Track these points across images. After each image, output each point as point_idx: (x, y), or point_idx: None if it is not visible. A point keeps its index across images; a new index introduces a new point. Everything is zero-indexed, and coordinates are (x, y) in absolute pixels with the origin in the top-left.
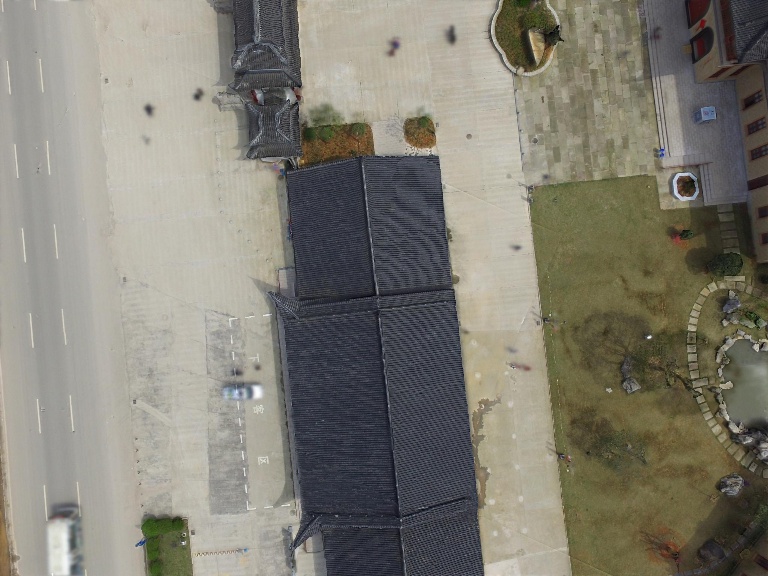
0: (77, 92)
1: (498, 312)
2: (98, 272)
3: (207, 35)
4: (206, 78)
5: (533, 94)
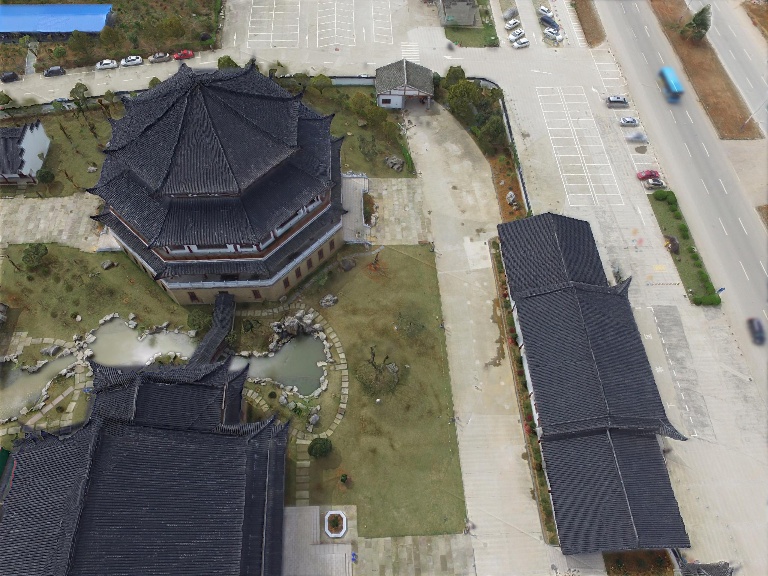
0: None
1: (489, 428)
2: None
3: None
4: None
5: None
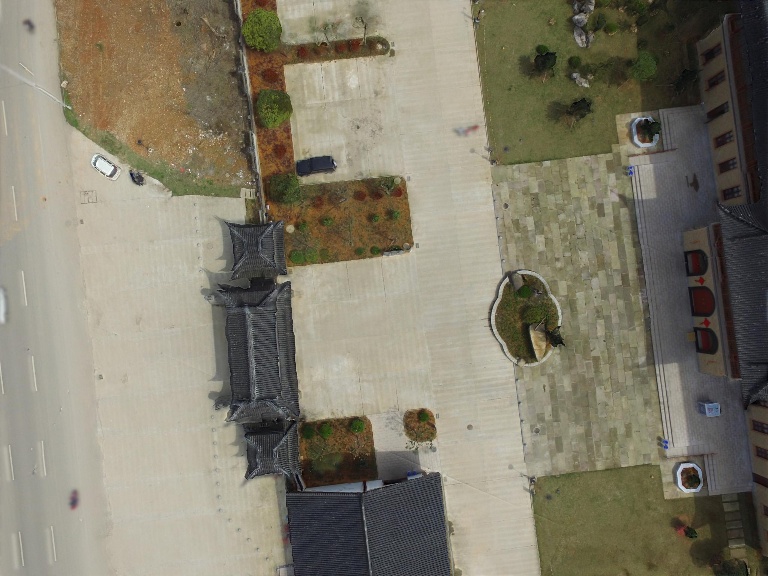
0: (71, 390)
1: None
2: (97, 573)
3: (202, 328)
4: (202, 373)
5: (534, 383)
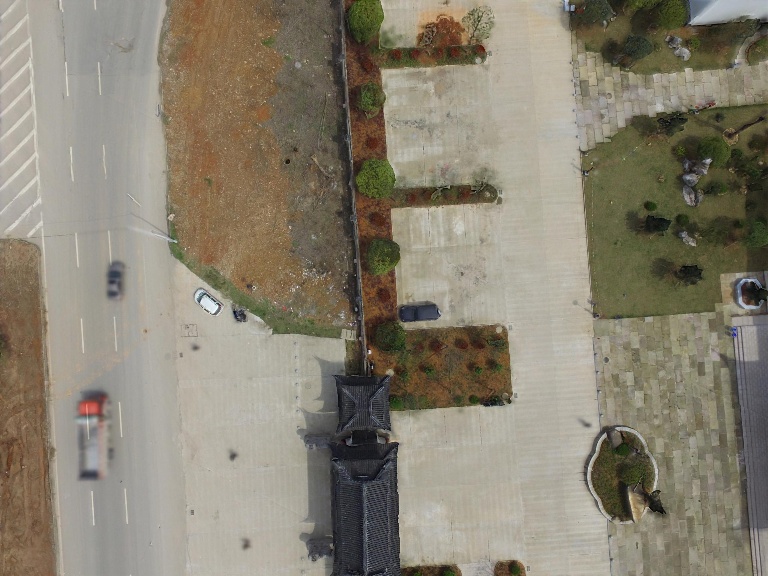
0: (162, 524)
1: None
2: None
3: (296, 468)
4: (294, 514)
5: (627, 540)
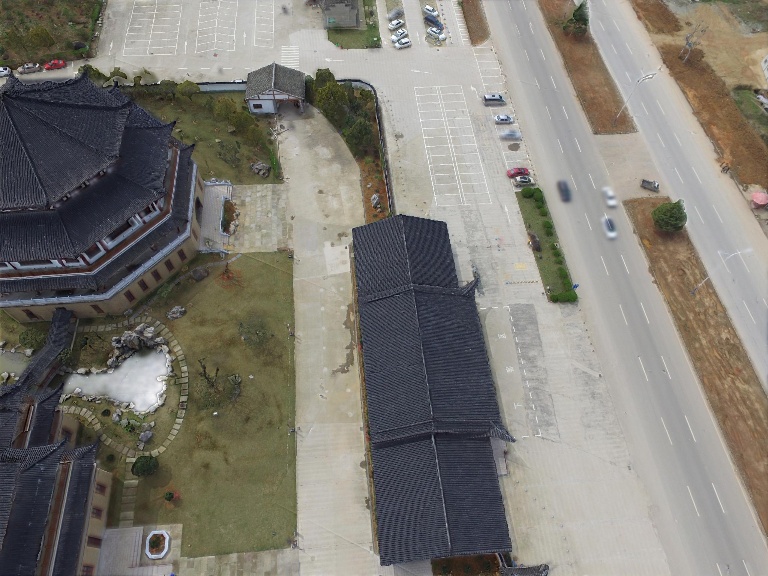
0: None
1: (330, 438)
2: (652, 475)
3: None
4: None
5: None
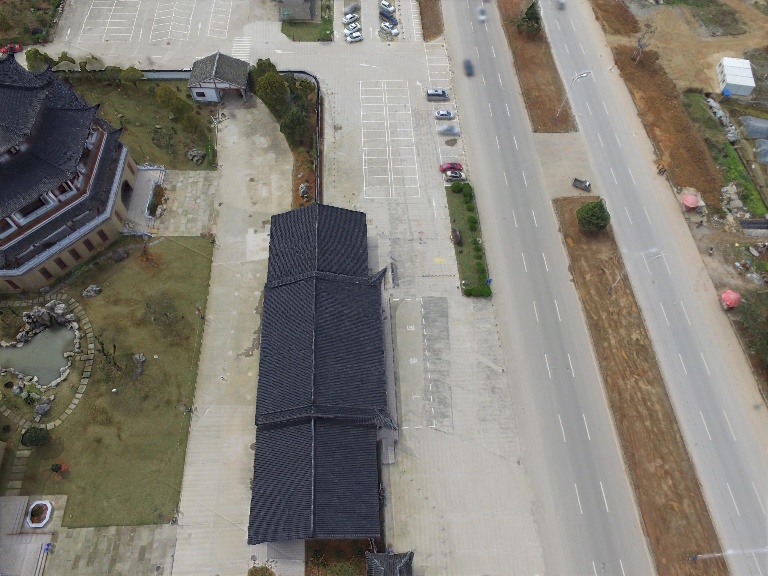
0: None
1: (225, 419)
2: (541, 470)
3: None
4: None
5: None
